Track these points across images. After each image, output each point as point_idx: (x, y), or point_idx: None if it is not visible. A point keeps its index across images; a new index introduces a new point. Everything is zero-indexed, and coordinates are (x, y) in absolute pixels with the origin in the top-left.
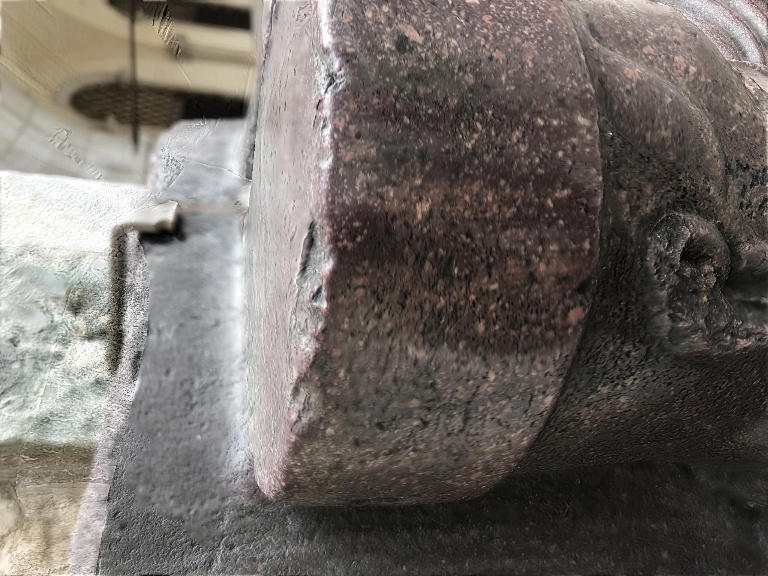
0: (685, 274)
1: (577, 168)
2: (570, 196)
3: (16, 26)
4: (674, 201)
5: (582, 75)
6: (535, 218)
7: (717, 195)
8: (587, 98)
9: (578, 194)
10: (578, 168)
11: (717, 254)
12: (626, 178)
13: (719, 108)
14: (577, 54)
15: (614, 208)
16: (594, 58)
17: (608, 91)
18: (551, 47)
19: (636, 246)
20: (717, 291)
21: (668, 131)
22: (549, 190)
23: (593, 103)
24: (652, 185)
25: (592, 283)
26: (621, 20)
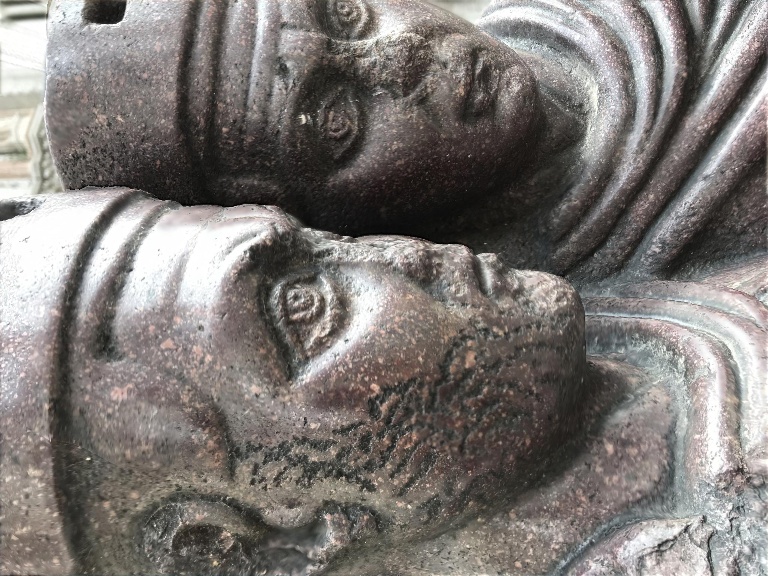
0: (180, 554)
1: (33, 510)
2: (31, 530)
3: (44, 37)
4: (170, 494)
5: (39, 428)
6: (7, 547)
7: (217, 482)
8: (40, 451)
9: (36, 529)
10: (33, 510)
11: (225, 527)
12: (108, 491)
13: (233, 394)
14: (40, 406)
15: (98, 517)
16: (80, 388)
17: (88, 419)
18: (15, 406)
19: (130, 538)
20: (237, 550)
21: (149, 444)
22: (11, 529)
23: (47, 453)
24: (137, 491)
25: (86, 573)
26: (150, 312)
